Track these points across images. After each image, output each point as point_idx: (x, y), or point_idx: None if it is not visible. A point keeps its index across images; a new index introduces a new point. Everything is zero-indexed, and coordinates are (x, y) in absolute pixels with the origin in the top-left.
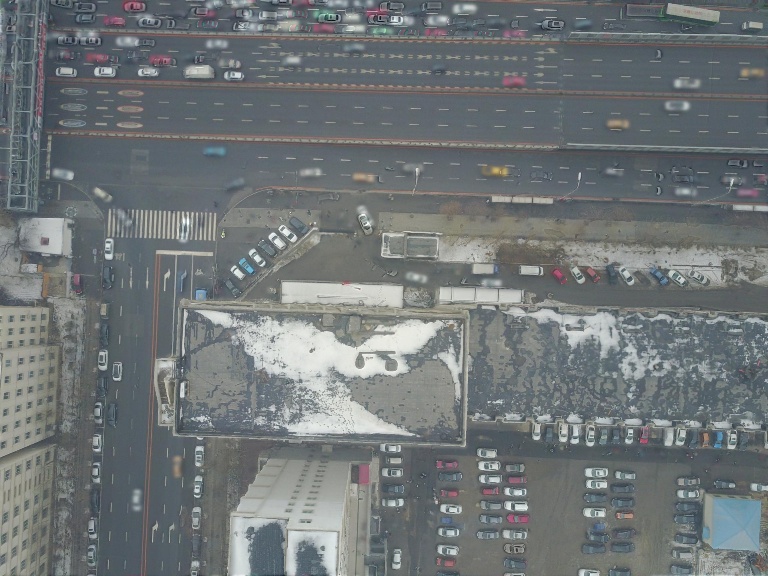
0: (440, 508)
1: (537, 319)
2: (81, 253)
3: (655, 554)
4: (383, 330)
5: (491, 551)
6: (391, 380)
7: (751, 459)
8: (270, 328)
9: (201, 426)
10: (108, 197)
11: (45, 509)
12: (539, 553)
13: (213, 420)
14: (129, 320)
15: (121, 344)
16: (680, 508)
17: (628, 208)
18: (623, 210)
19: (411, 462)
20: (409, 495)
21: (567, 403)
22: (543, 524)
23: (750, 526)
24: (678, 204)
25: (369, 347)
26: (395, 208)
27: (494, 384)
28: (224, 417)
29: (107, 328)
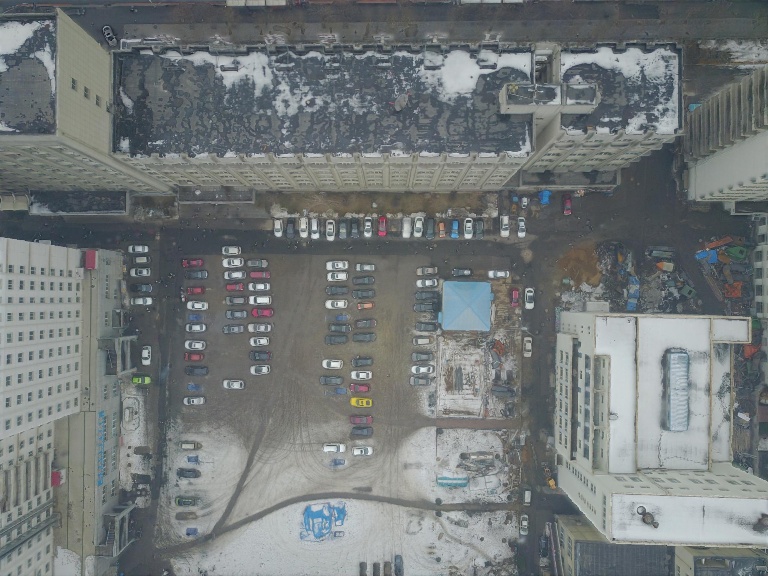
0: (187, 305)
1: (193, 62)
2: None
3: (397, 343)
4: None
5: (238, 346)
6: None
7: (489, 248)
8: None
9: None
10: None
11: None
12: (284, 346)
13: None
14: None
15: None
16: (419, 297)
17: (364, 10)
18: (347, 4)
19: (159, 263)
20: (158, 295)
21: (224, 141)
22: (288, 319)
23: (477, 304)
24: None
25: None
26: (139, 20)
27: (154, 126)
28: None
29: None
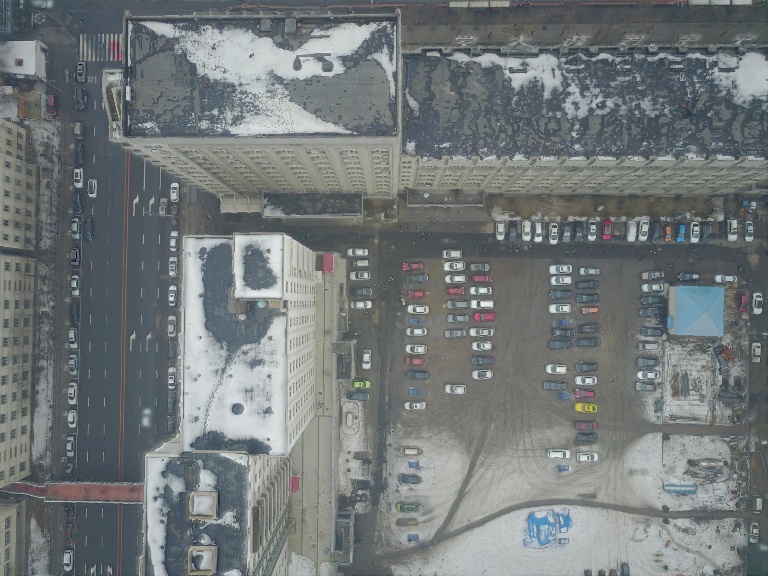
0: (408, 309)
1: (481, 63)
2: (55, 77)
3: (621, 348)
4: (319, 34)
5: (459, 350)
6: (327, 80)
7: (715, 253)
8: (211, 36)
9: (148, 132)
10: (79, 23)
11: (27, 319)
12: (506, 351)
13: (159, 126)
14: (102, 140)
15: (95, 163)
16: (645, 301)
17: None
18: (578, 5)
19: (378, 266)
20: (377, 298)
21: (512, 144)
22: (510, 323)
23: (713, 309)
24: (635, 5)
25: (306, 50)
26: None
27: (440, 128)
28: (169, 122)
29: (81, 147)
